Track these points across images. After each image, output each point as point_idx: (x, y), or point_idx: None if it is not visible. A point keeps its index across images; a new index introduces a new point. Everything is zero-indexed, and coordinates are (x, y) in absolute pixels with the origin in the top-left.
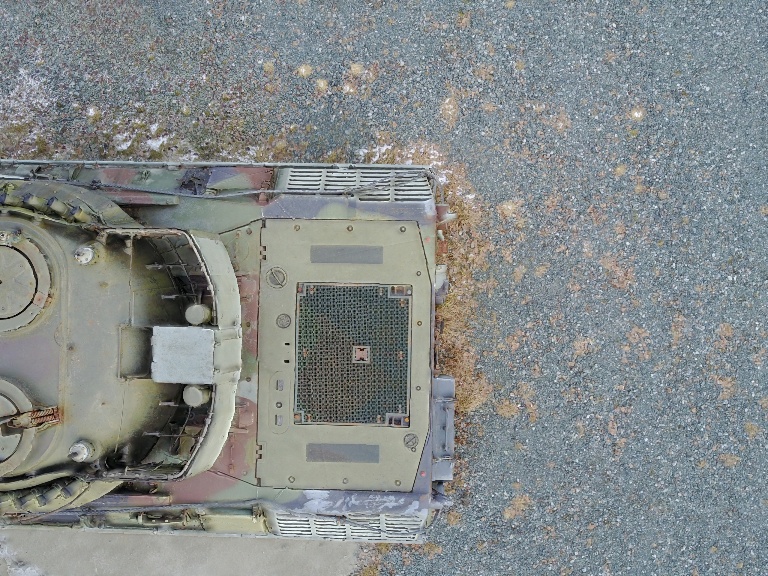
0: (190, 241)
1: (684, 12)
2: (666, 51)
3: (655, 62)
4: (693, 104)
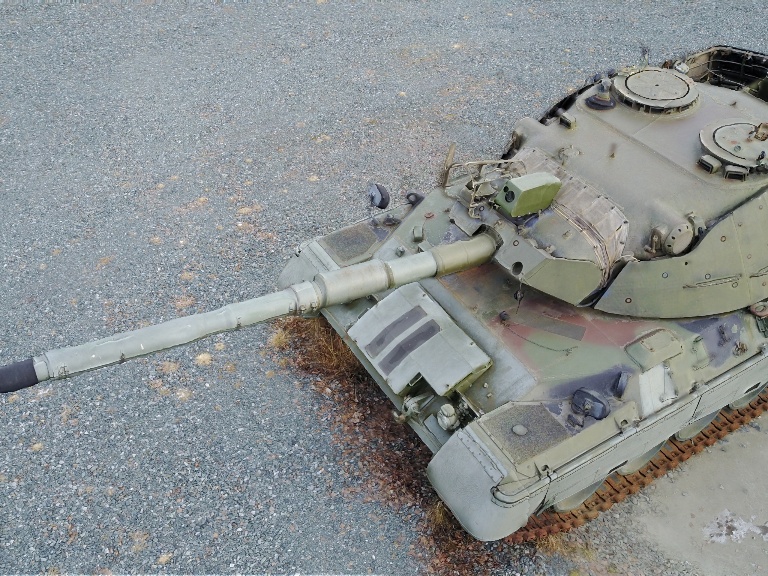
0: (727, 48)
1: None
2: None
3: None
4: None
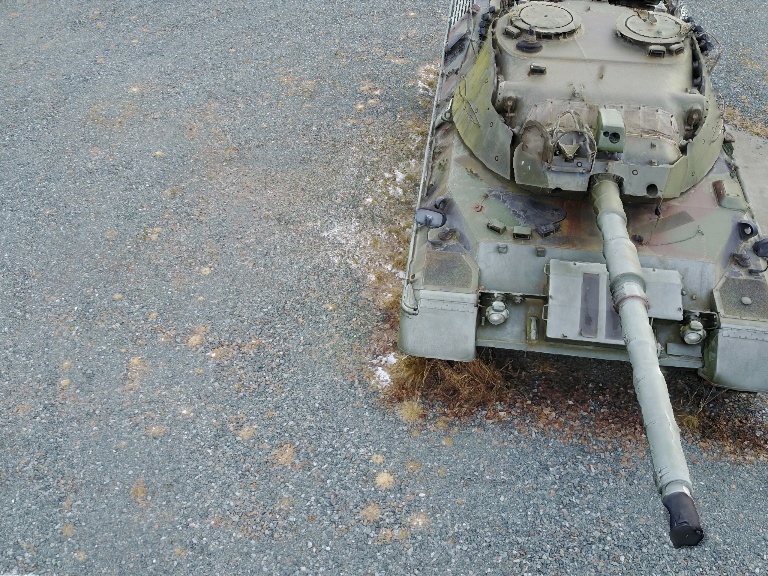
0: None
1: (357, 0)
2: (378, 5)
3: (383, 8)
4: (409, 1)
